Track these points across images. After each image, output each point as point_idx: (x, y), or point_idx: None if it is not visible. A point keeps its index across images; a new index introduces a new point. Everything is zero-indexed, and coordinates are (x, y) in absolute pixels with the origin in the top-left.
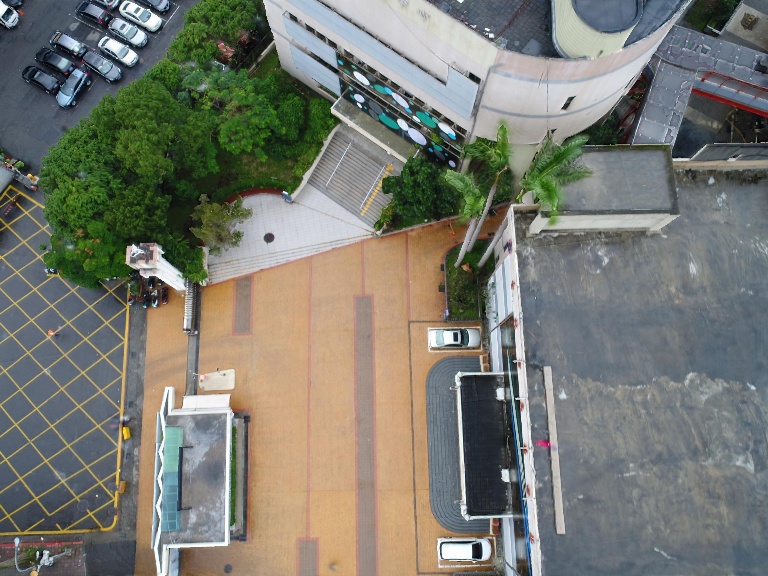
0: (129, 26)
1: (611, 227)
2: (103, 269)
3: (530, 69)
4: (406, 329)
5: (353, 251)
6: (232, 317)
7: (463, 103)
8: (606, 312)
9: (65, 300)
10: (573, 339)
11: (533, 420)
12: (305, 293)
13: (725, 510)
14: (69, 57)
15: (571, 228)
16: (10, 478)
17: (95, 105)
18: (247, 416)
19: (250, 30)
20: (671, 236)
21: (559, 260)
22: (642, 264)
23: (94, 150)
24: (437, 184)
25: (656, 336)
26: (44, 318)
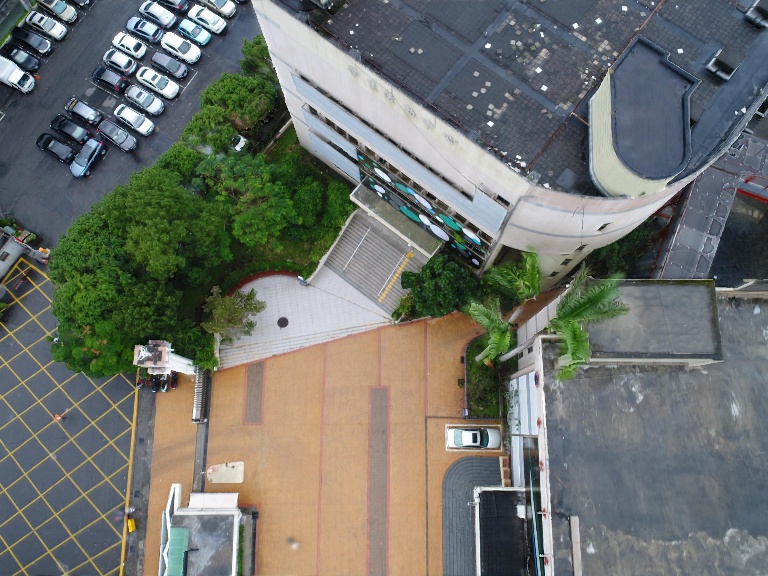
0: (146, 94)
1: (647, 361)
2: (110, 366)
3: (564, 203)
4: (423, 425)
5: (369, 339)
6: (243, 405)
7: (490, 220)
8: (639, 456)
9: (73, 381)
10: (603, 486)
11: (558, 575)
12: (319, 382)
13: None
14: (84, 124)
15: (603, 361)
16: (12, 568)
17: (109, 175)
18: (255, 512)
19: (268, 110)
20: (712, 372)
21: (589, 396)
22: (679, 403)
23: (104, 243)
24: (459, 286)
25: (693, 485)
26: (51, 399)
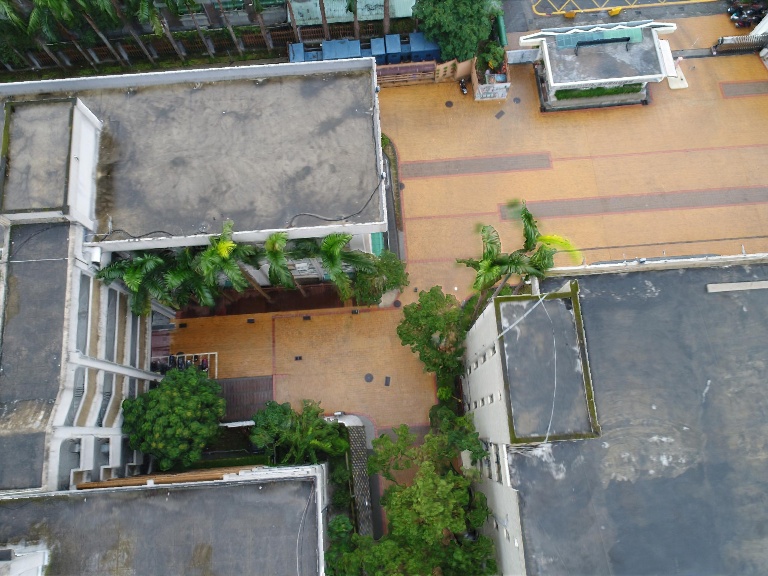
0: None
1: None
2: None
3: None
4: (762, 234)
5: None
6: (736, 80)
7: None
8: None
9: None
10: None
11: None
12: None
13: (762, 457)
14: None
15: None
16: None
17: None
18: (647, 102)
19: None
20: None
21: None
22: None
23: None
24: None
25: None
26: None
